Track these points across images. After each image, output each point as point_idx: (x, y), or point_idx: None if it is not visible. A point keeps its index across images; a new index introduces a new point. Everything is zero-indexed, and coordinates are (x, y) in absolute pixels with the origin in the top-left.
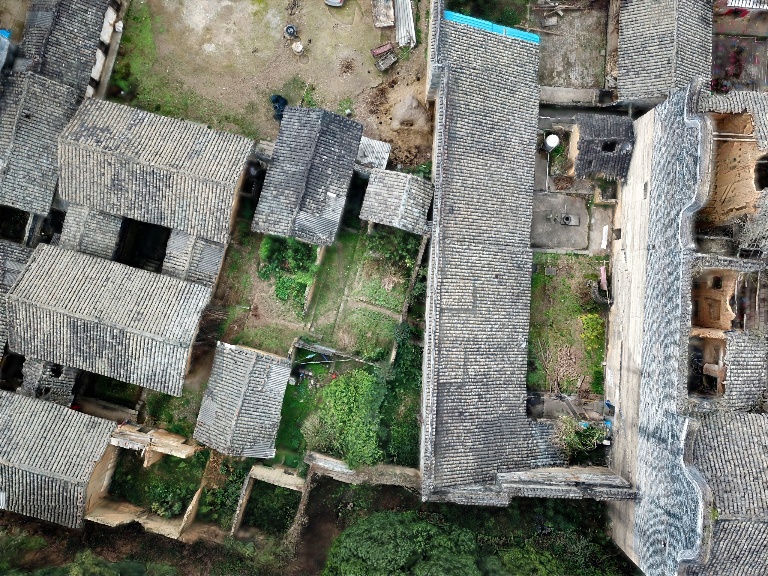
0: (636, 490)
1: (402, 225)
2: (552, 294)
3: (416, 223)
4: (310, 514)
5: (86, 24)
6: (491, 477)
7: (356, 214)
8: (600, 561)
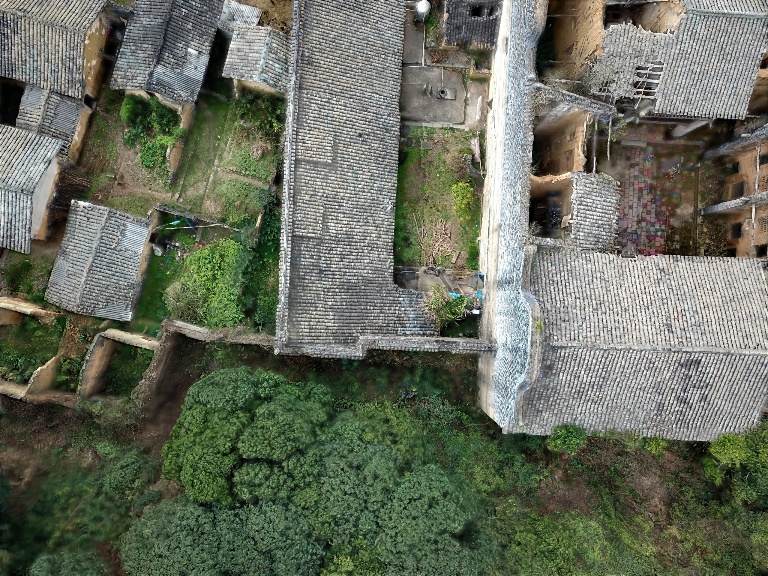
0: None
1: (263, 80)
2: (428, 168)
3: (279, 80)
4: (171, 384)
5: None
6: (353, 340)
7: (227, 83)
8: (465, 426)
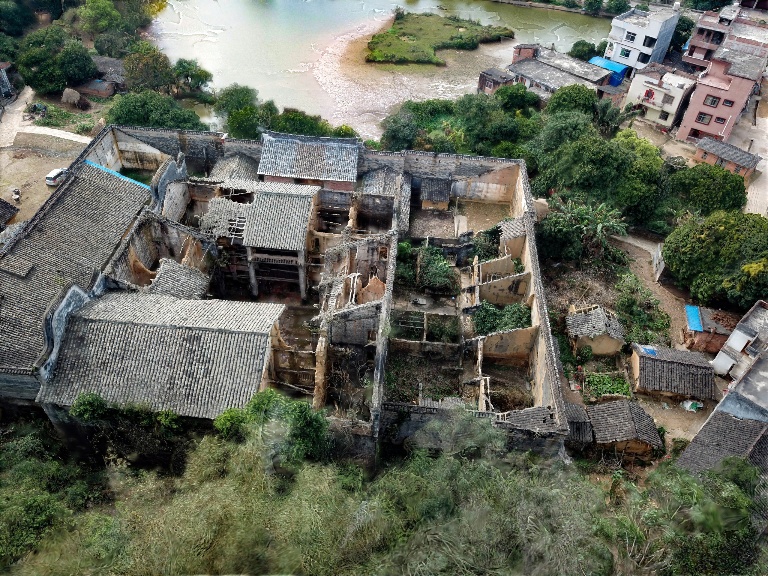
0: None
1: None
2: None
3: None
4: None
5: None
6: None
7: None
8: None
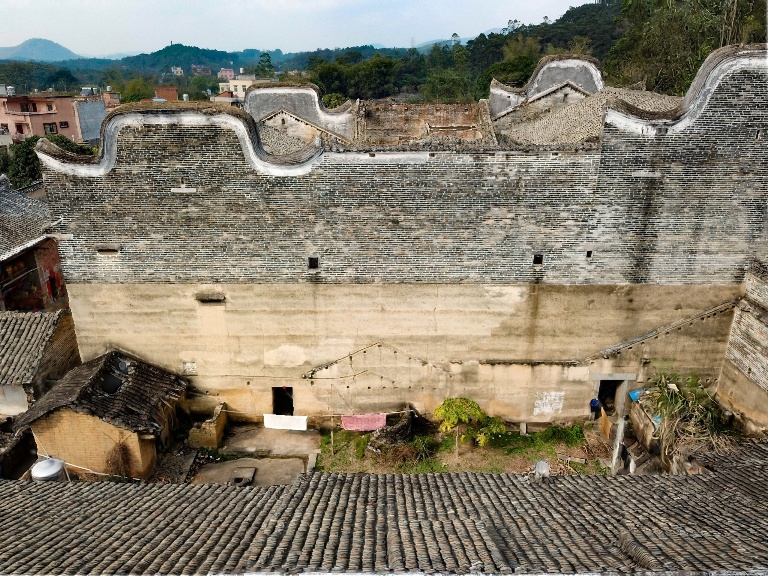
0: (745, 282)
1: None
2: None
3: None
4: None
5: None
6: None
7: None
8: None
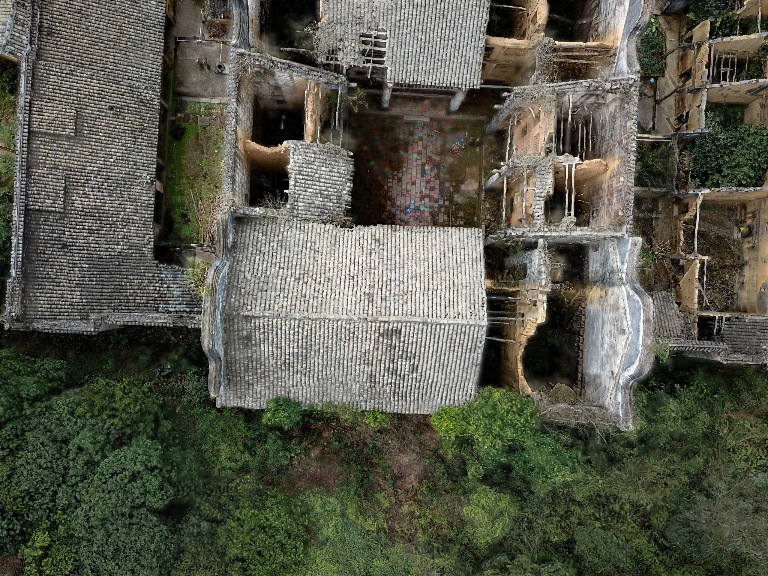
0: None
1: (9, 52)
2: (205, 144)
3: None
4: None
5: None
6: None
7: None
8: None
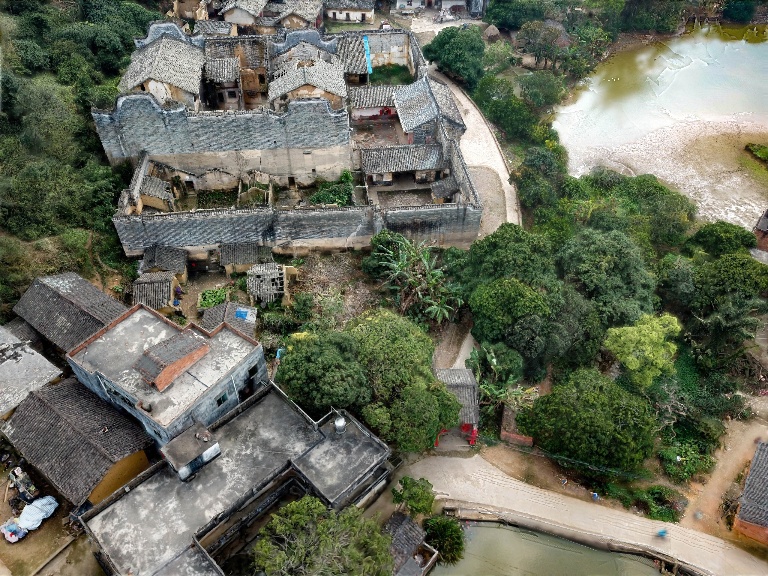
0: None
1: None
2: None
3: None
4: None
5: (351, 5)
6: None
7: None
8: None
